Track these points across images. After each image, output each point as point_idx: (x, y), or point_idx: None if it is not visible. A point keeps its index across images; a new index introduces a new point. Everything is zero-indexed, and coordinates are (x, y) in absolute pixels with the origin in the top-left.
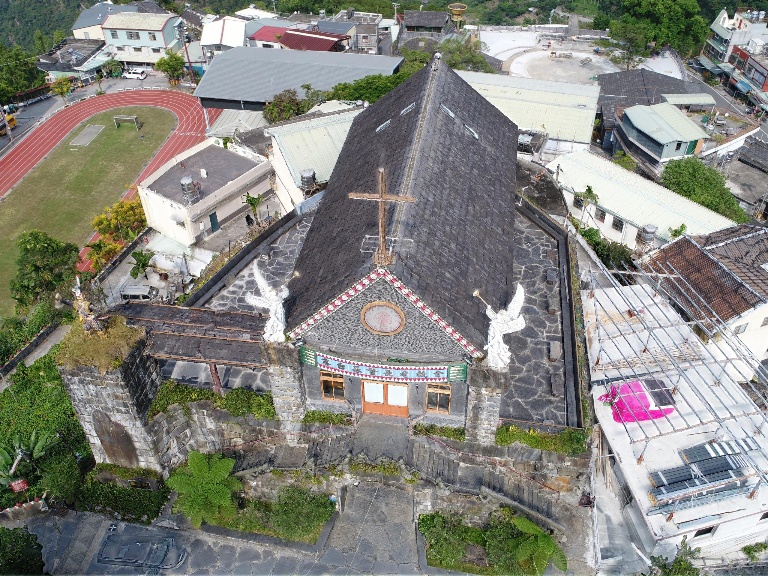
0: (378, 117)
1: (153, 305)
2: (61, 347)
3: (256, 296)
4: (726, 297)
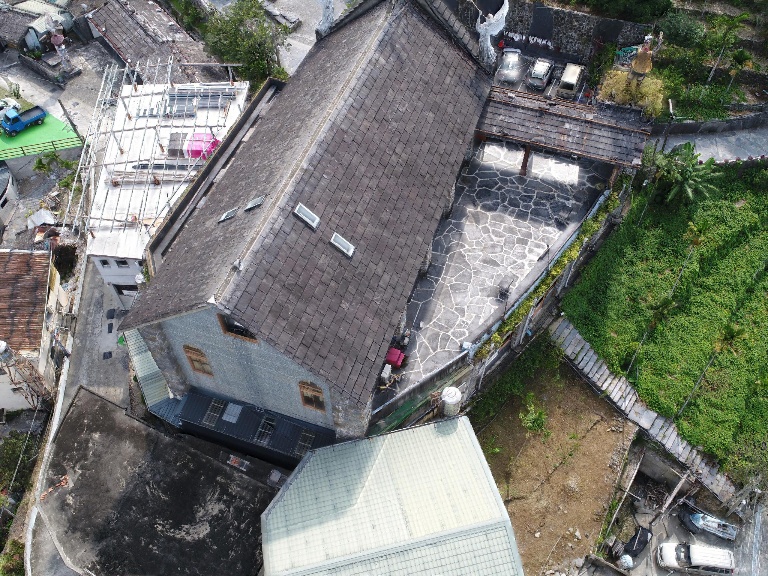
0: (341, 297)
1: (607, 159)
2: (766, 450)
3: (501, 9)
4: (2, 271)
